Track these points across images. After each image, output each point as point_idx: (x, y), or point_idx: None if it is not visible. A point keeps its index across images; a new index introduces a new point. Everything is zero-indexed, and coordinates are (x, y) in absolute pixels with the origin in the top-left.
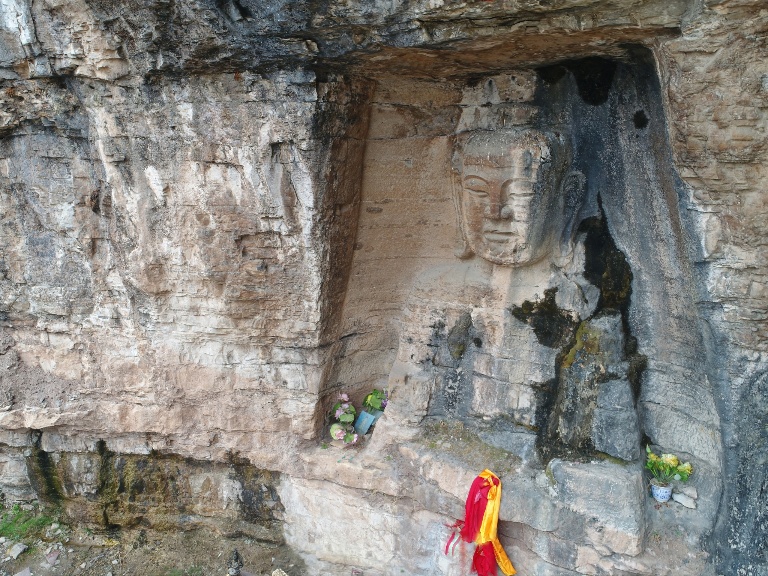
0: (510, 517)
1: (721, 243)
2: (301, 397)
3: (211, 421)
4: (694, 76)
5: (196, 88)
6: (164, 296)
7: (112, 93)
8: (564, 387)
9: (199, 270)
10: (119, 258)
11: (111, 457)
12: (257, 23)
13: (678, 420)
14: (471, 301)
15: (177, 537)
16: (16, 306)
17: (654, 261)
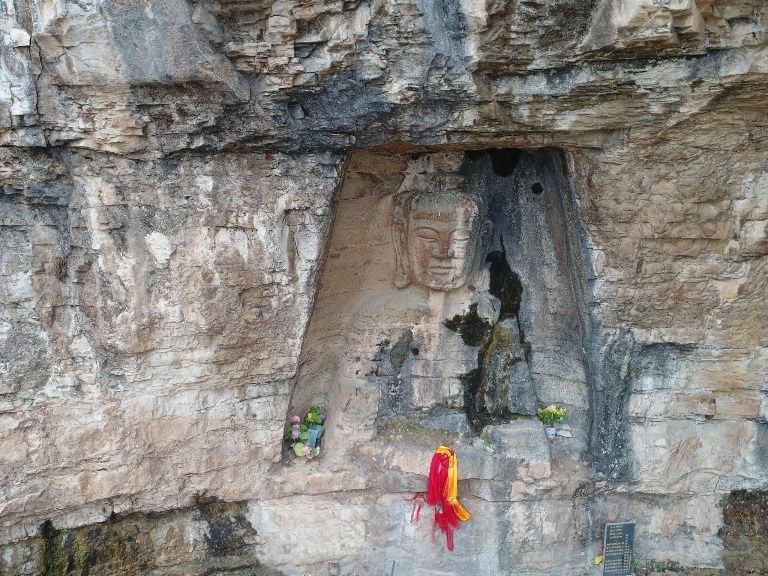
0: (465, 476)
1: (604, 267)
2: (270, 426)
3: (181, 468)
4: (609, 176)
5: (221, 164)
6: (145, 354)
7: (117, 165)
8: (486, 373)
9: (197, 325)
10: (92, 323)
11: (56, 537)
12: (314, 121)
13: (552, 382)
14: (412, 320)
15: None
16: None
17: (539, 278)
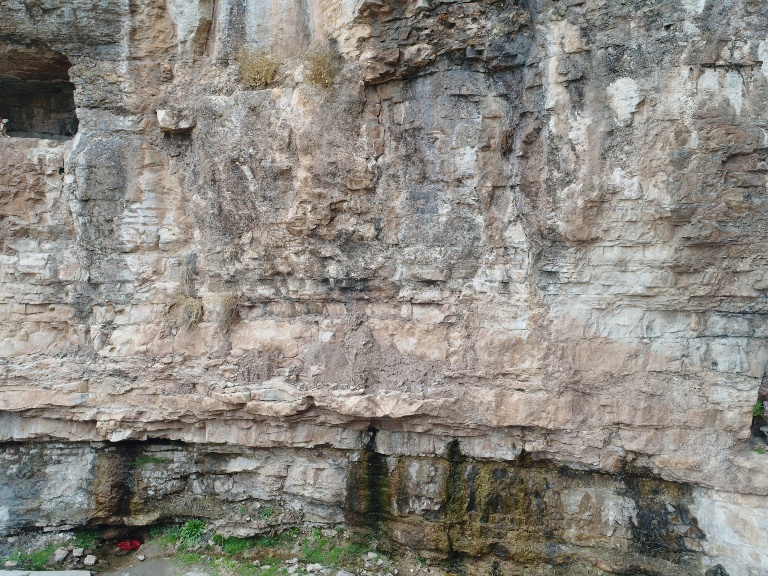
0: None
1: None
2: (737, 382)
3: (609, 414)
4: None
5: None
6: (585, 248)
7: None
8: None
9: (659, 204)
10: (531, 205)
11: (460, 464)
12: None
13: None
14: None
15: (544, 572)
16: (382, 271)
17: None
